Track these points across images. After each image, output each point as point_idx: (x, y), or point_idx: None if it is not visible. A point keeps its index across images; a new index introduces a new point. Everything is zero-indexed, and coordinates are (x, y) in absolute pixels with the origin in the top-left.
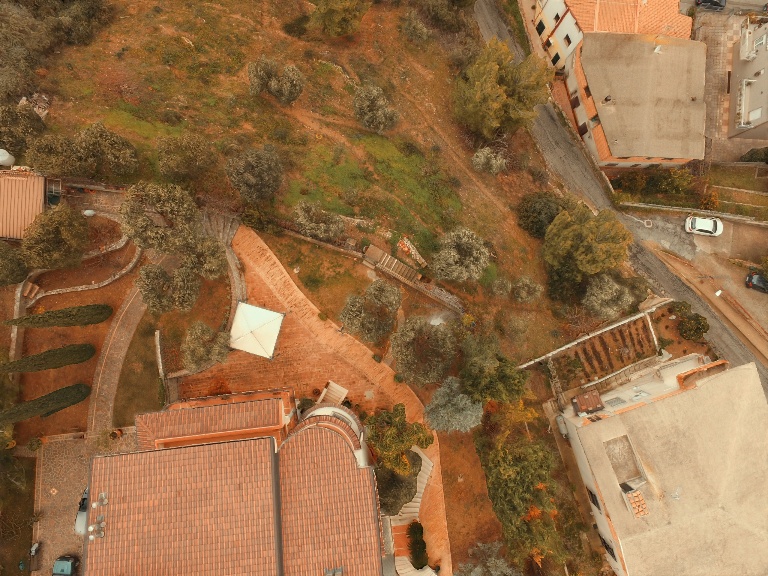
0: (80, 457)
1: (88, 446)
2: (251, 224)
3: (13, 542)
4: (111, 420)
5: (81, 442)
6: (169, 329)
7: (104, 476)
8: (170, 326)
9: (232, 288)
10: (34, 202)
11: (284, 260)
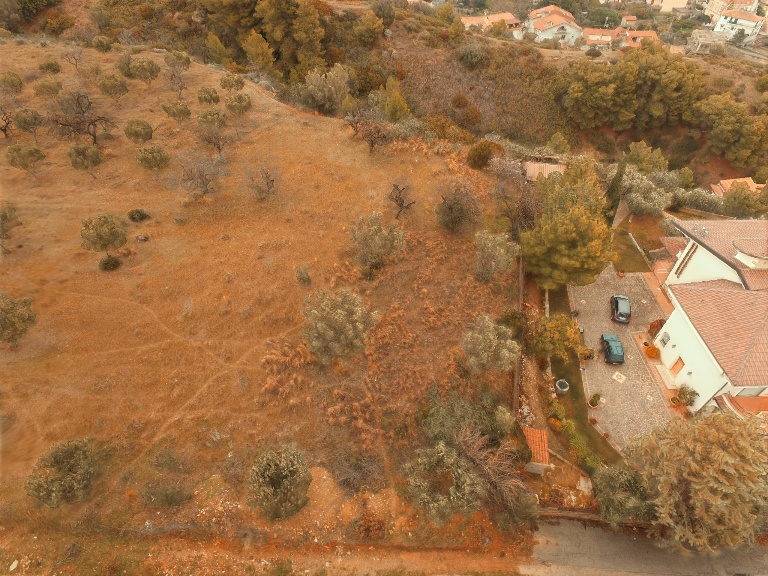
0: (598, 285)
1: (602, 280)
2: None
3: None
4: (614, 269)
5: (596, 278)
6: (636, 234)
7: None
8: None
9: None
10: (562, 172)
11: None
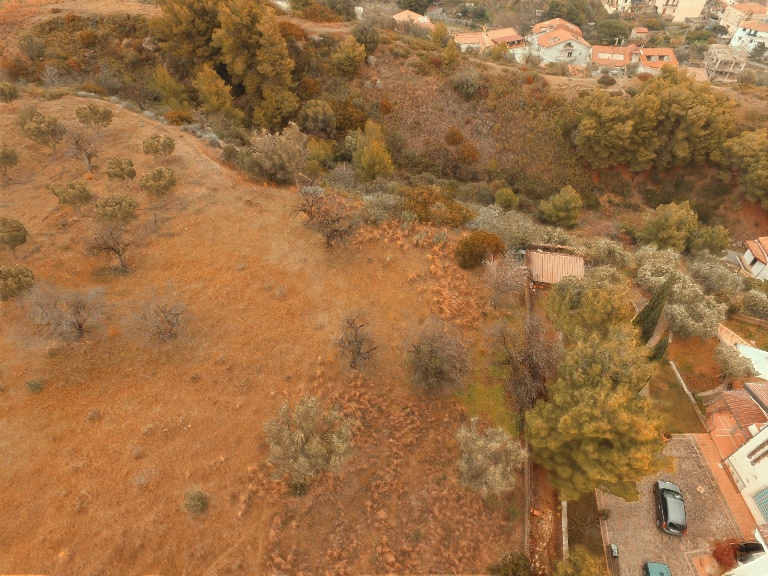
0: None
1: None
2: (721, 299)
3: (581, 544)
4: None
5: None
6: (679, 362)
7: (767, 395)
8: (679, 360)
9: (720, 339)
10: (578, 268)
11: (739, 335)
